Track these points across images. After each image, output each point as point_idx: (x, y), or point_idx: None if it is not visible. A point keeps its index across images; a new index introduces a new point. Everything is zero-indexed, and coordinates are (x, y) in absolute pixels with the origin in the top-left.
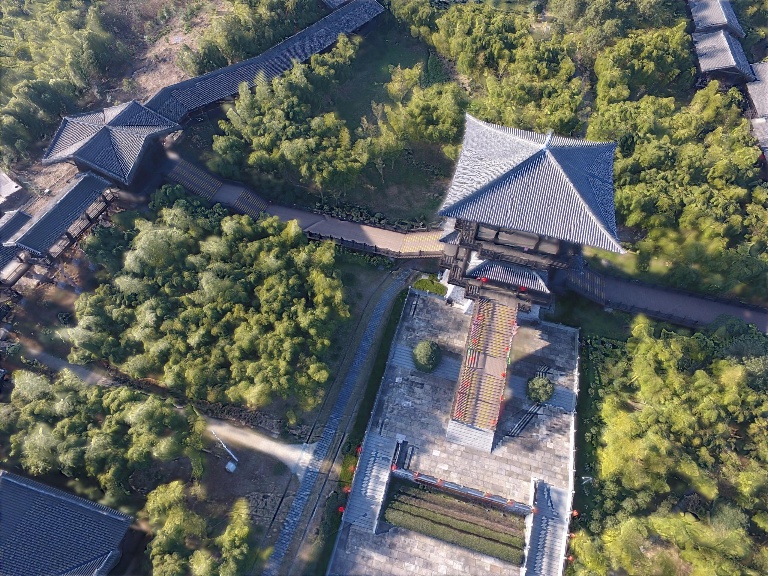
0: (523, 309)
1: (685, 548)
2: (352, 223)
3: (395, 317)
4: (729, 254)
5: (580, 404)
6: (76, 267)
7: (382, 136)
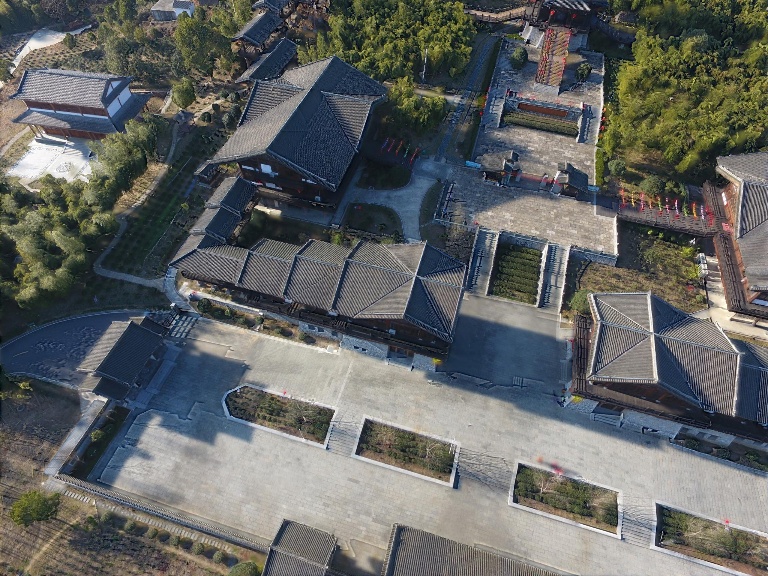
0: (573, 33)
1: (661, 112)
2: (465, 9)
3: (497, 48)
4: (691, 9)
5: (606, 81)
6: (310, 21)
7: None
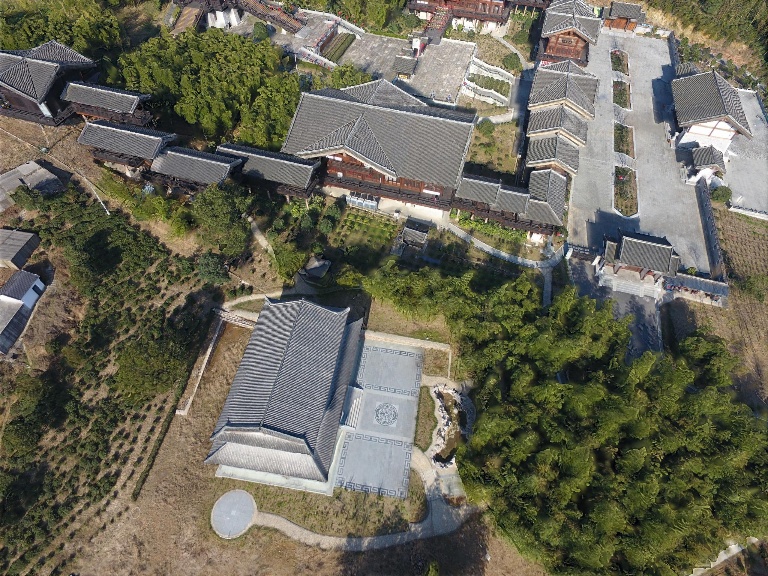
0: None
1: None
2: None
3: None
4: None
5: None
6: None
7: (88, 5)
